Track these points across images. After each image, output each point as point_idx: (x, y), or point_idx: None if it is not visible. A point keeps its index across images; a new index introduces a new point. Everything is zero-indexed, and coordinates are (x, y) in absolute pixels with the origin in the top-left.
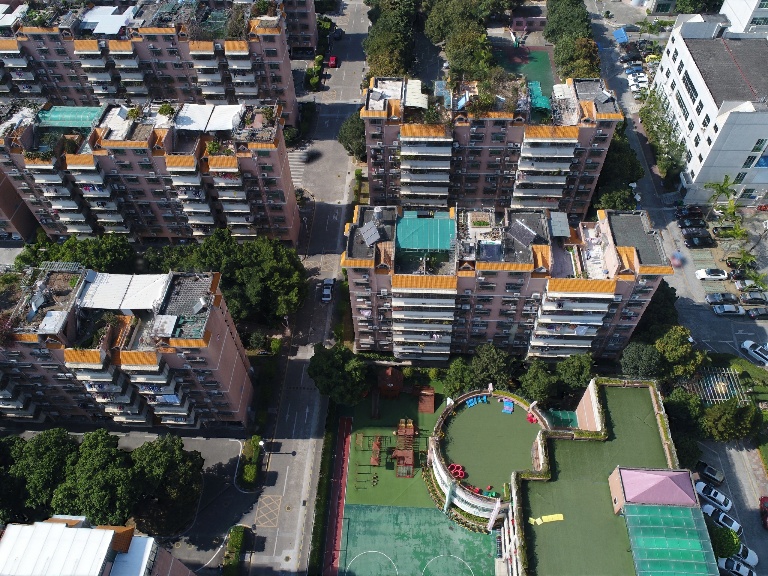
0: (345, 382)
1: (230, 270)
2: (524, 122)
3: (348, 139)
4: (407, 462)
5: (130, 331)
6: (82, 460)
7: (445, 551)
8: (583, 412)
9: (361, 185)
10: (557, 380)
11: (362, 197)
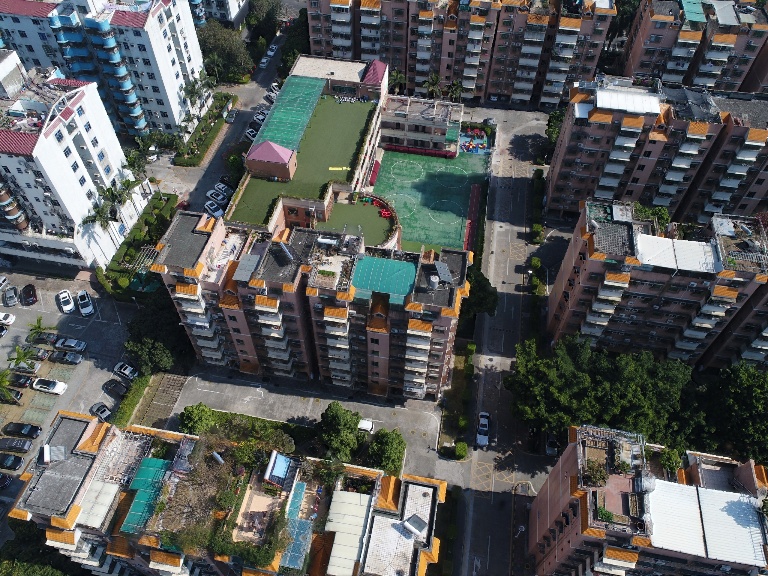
0: None
1: None
2: None
3: None
4: None
5: None
6: None
7: None
8: None
9: None
10: None
11: None
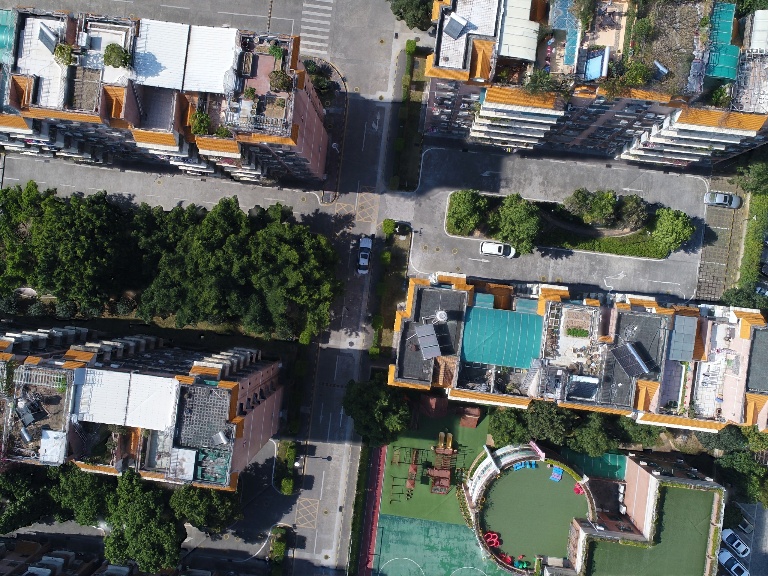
0: (385, 433)
1: (244, 270)
2: (684, 102)
3: (399, 3)
4: (443, 484)
5: (143, 442)
6: (122, 503)
7: (469, 564)
8: (635, 479)
9: (413, 64)
10: (616, 427)
11: (414, 89)
